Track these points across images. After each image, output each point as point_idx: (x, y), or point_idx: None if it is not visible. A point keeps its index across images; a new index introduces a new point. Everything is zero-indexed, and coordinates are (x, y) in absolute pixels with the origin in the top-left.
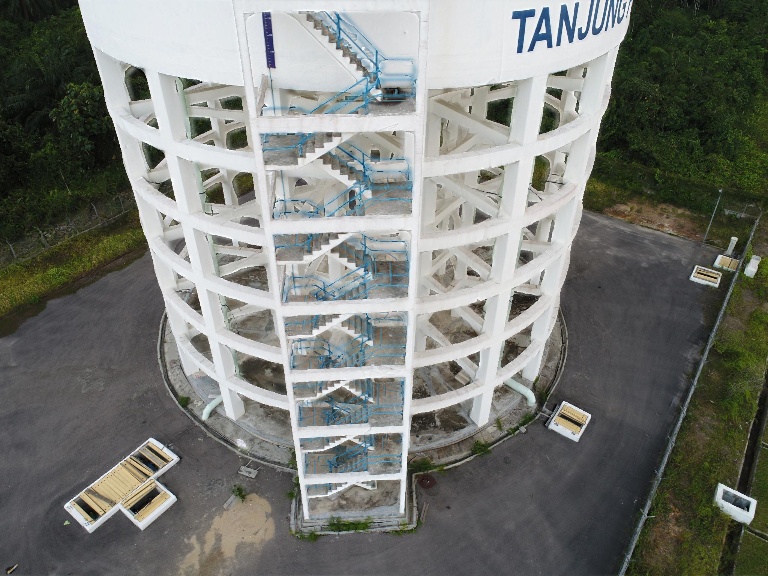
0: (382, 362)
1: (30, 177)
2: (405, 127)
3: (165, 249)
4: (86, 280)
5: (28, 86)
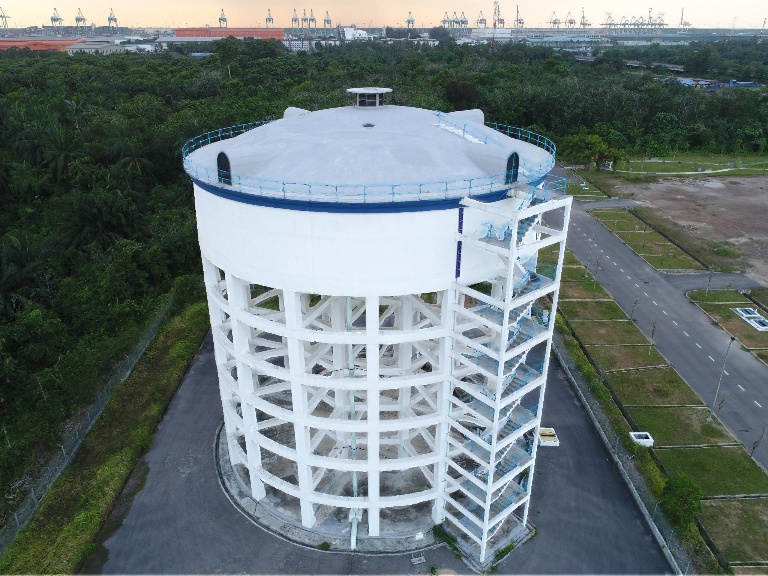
0: (526, 421)
1: None
2: (554, 289)
3: (326, 420)
4: (119, 511)
5: None
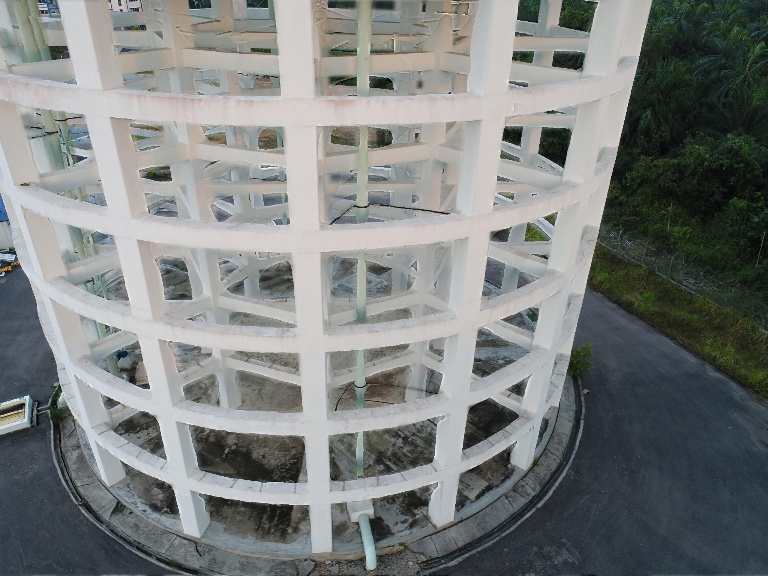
0: None
1: (719, 217)
2: None
3: None
4: (506, 237)
5: None
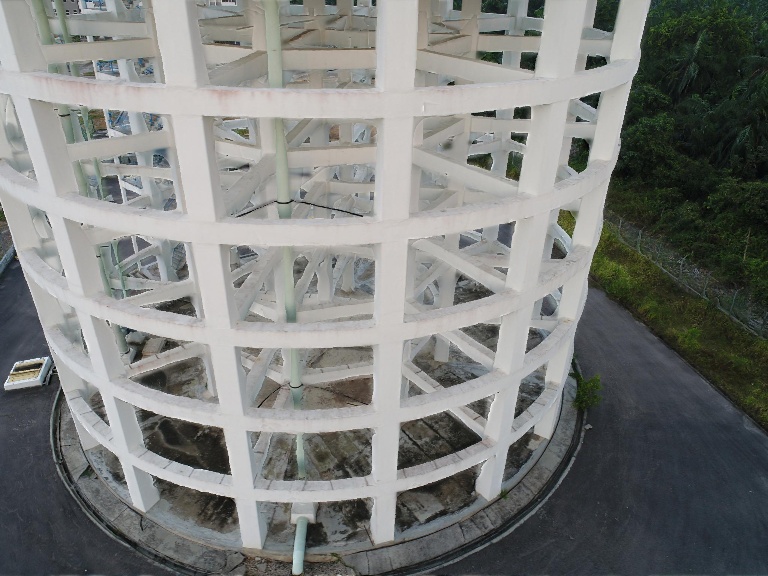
0: None
1: None
2: None
3: None
4: (556, 253)
5: None
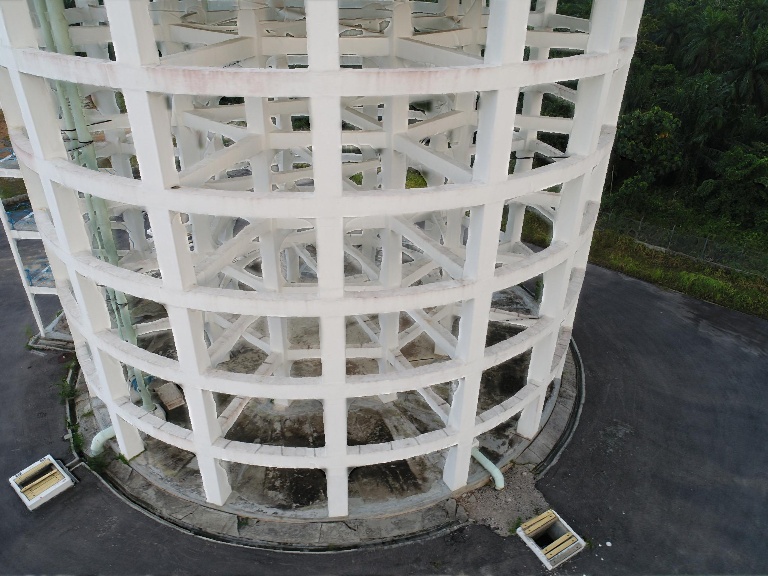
0: (6, 161)
1: None
2: None
3: None
4: None
5: (654, 103)
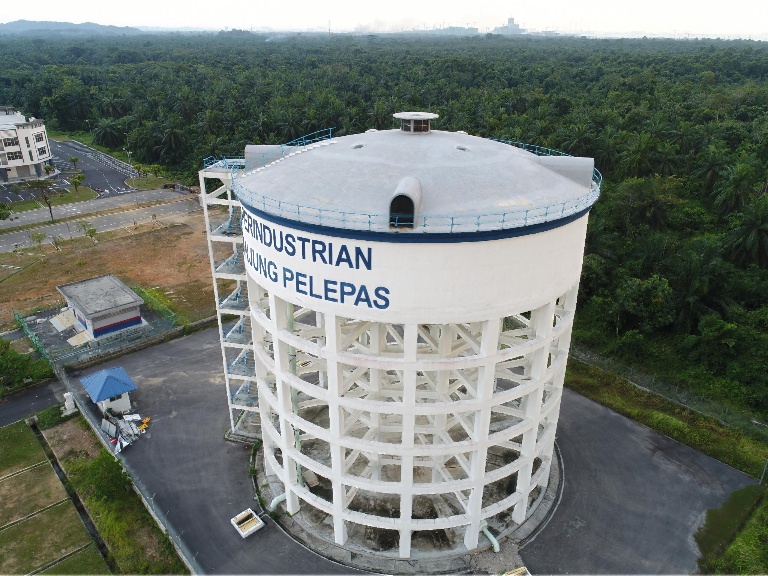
0: (230, 336)
1: None
2: None
3: None
4: None
5: (659, 267)
